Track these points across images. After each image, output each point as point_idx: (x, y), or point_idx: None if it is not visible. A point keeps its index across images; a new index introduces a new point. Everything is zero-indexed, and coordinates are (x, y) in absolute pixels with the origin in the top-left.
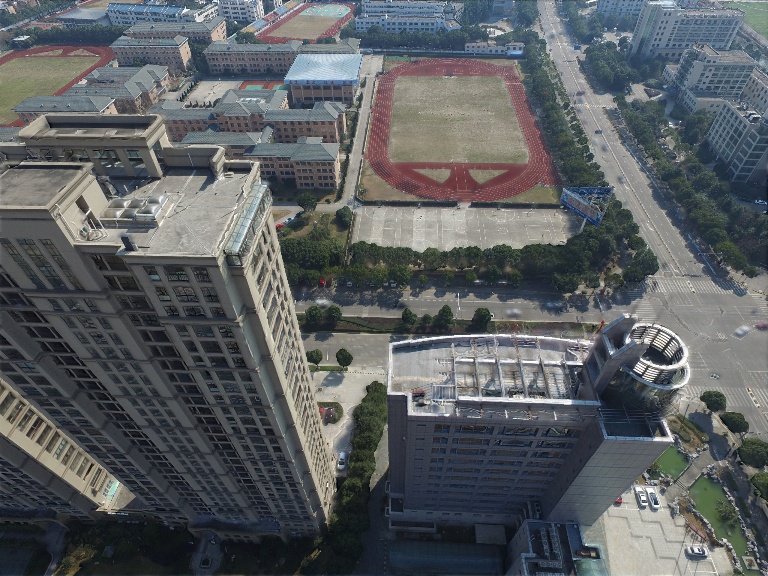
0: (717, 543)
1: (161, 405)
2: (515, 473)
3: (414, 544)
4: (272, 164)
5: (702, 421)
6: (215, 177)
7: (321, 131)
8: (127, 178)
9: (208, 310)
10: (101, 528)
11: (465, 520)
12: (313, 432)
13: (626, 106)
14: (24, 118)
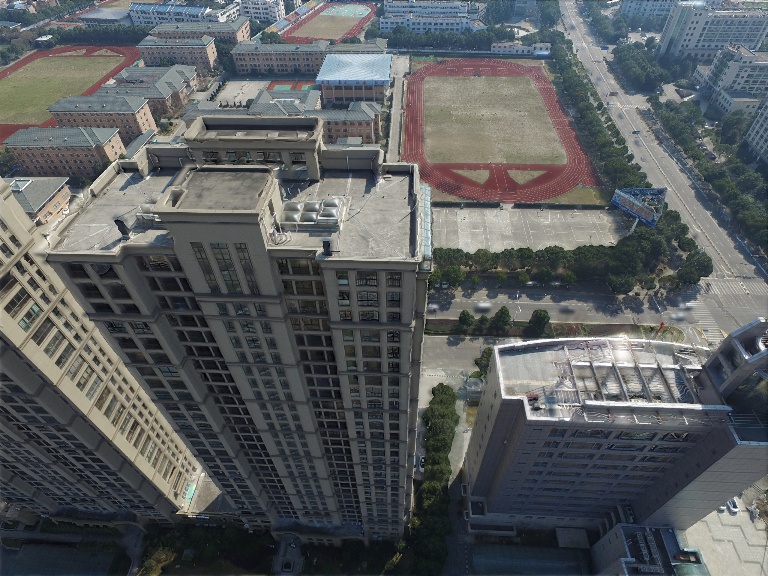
0: None
1: (290, 409)
2: (615, 477)
3: (496, 548)
4: None
5: None
6: (376, 180)
7: (357, 131)
8: (289, 181)
9: (385, 315)
10: (181, 531)
11: (546, 524)
12: None
13: (660, 107)
14: (58, 118)
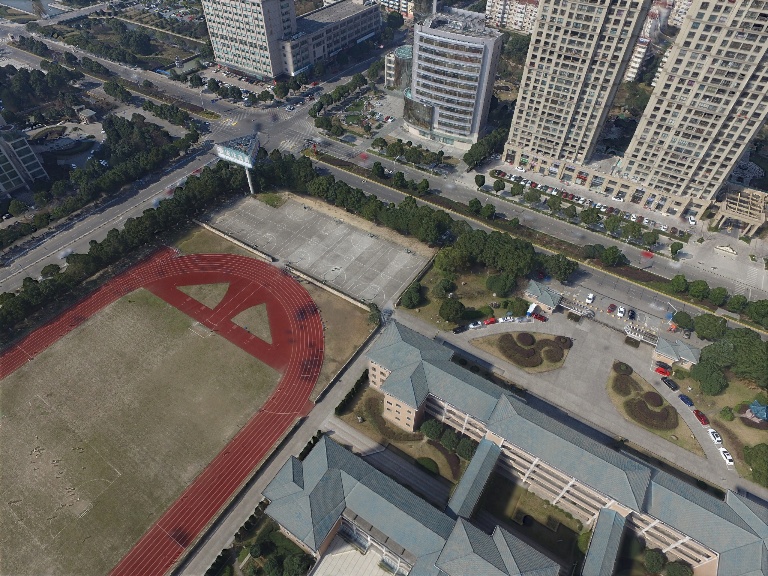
0: (369, 102)
1: None
2: None
3: None
4: None
5: None
6: None
7: None
8: None
9: None
10: None
11: None
12: None
13: None
14: None
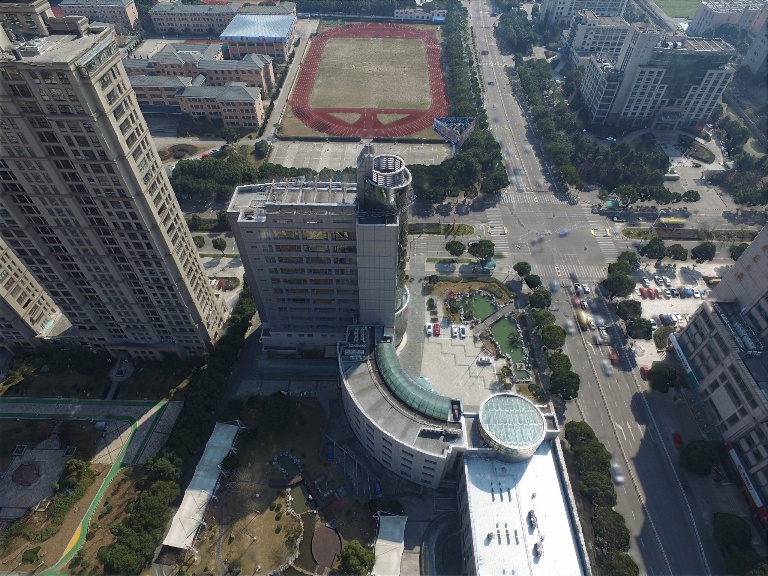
0: (500, 355)
1: (62, 204)
2: (332, 283)
3: (279, 359)
4: (201, 105)
5: (515, 285)
6: (82, 35)
7: (249, 80)
8: (25, 34)
9: (73, 107)
10: (39, 351)
11: (318, 343)
12: (186, 253)
13: (522, 64)
14: None
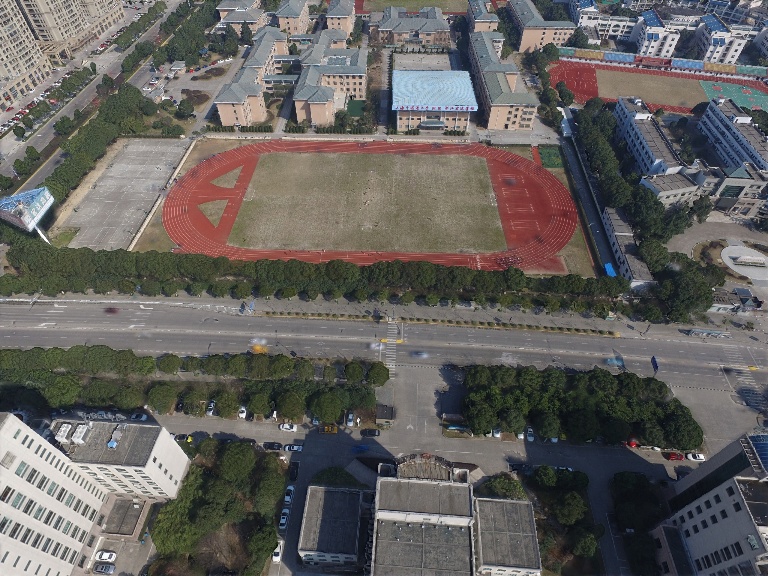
0: None
1: None
2: None
3: None
4: None
5: None
6: None
7: None
8: None
9: None
10: None
11: None
12: None
13: None
14: None
